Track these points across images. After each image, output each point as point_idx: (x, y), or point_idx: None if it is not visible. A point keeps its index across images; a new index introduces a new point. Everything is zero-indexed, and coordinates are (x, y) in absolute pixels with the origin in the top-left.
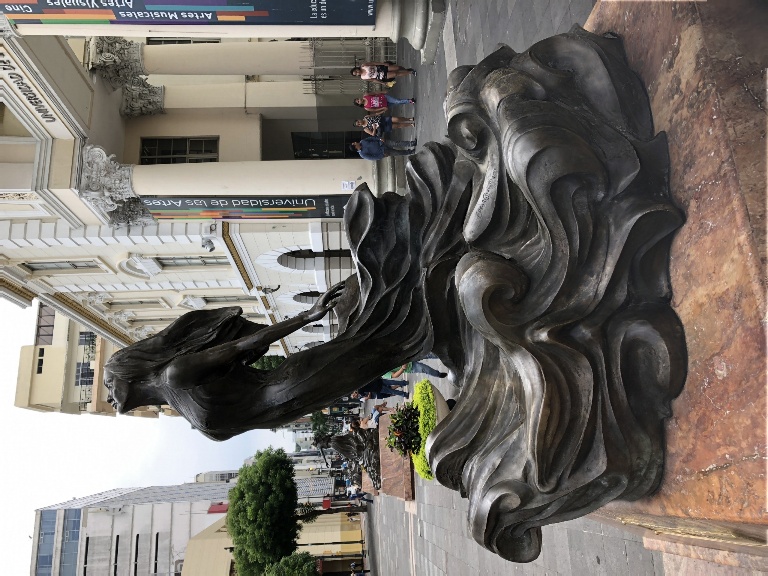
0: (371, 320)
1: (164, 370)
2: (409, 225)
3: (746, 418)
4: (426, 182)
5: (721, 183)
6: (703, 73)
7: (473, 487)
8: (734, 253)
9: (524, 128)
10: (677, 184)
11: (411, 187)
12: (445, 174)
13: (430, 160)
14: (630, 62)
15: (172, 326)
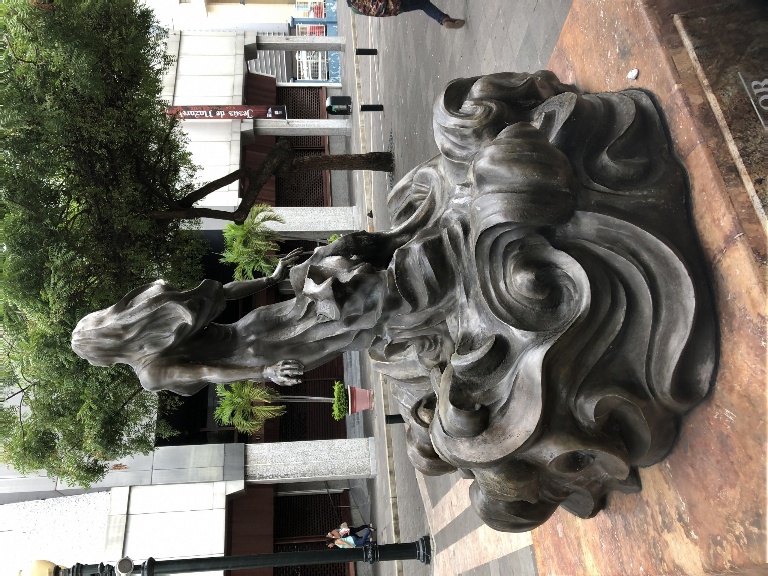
0: (329, 337)
1: (137, 372)
2: (380, 316)
3: (552, 551)
4: (409, 300)
5: (619, 570)
6: (671, 574)
7: (397, 400)
8: (595, 570)
9: (492, 522)
10: (616, 502)
11: (390, 288)
12: (435, 298)
13: (421, 285)
14: (688, 420)
15: (124, 324)
